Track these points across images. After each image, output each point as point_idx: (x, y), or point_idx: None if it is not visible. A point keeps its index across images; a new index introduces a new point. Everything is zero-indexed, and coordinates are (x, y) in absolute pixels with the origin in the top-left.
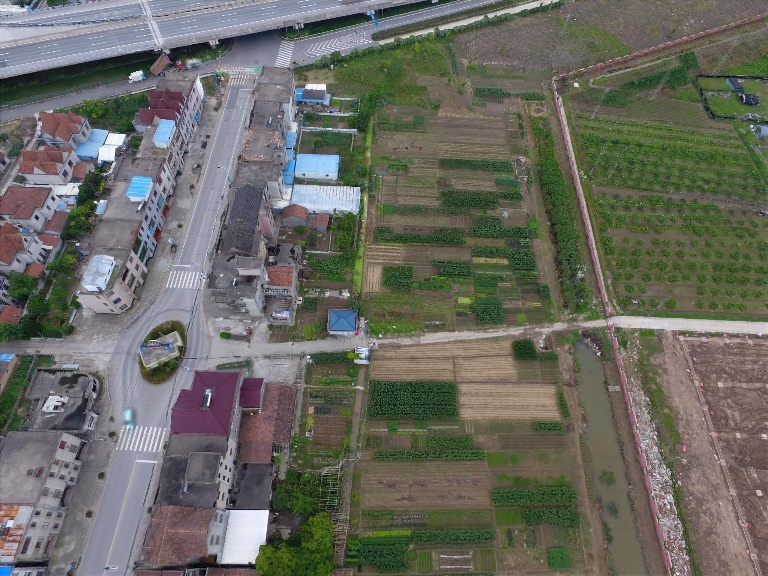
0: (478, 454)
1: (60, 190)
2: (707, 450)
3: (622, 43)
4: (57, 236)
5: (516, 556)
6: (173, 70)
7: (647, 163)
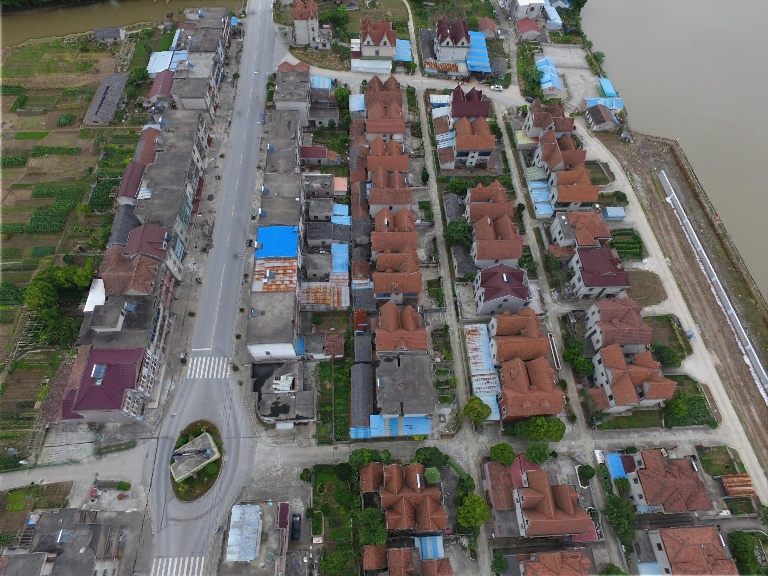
0: None
1: None
2: None
3: None
4: None
5: None
6: None
7: None
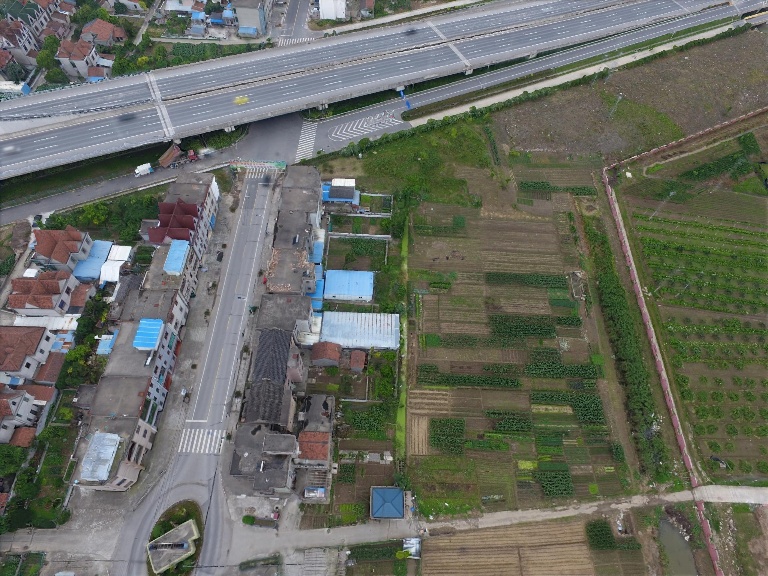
0: None
1: (56, 323)
2: None
3: (675, 123)
4: (51, 386)
5: None
6: (184, 161)
7: (717, 276)
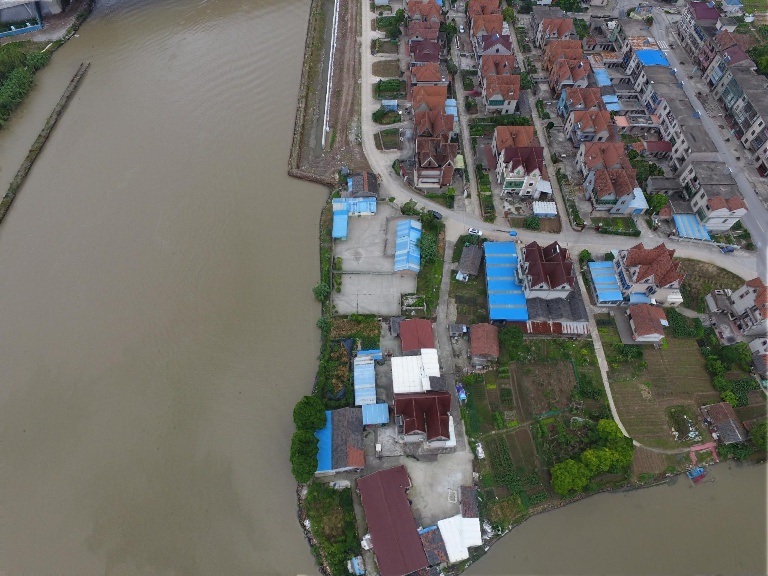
0: None
1: None
2: None
3: None
4: None
5: None
6: None
7: None
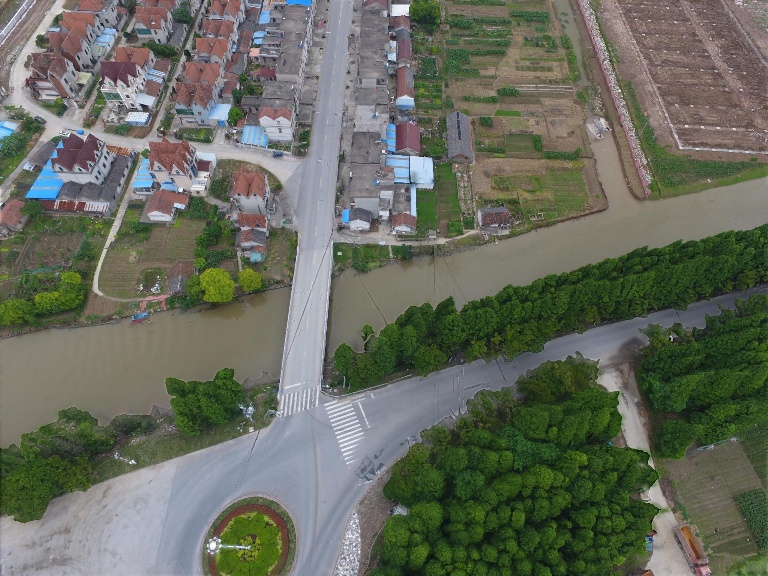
0: (503, 2)
1: None
2: (613, 8)
3: None
4: None
5: (521, 28)
6: None
7: None
